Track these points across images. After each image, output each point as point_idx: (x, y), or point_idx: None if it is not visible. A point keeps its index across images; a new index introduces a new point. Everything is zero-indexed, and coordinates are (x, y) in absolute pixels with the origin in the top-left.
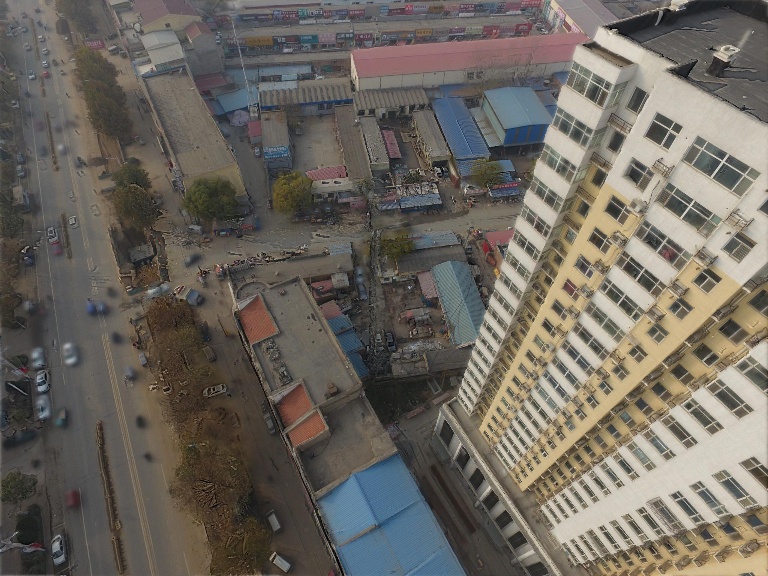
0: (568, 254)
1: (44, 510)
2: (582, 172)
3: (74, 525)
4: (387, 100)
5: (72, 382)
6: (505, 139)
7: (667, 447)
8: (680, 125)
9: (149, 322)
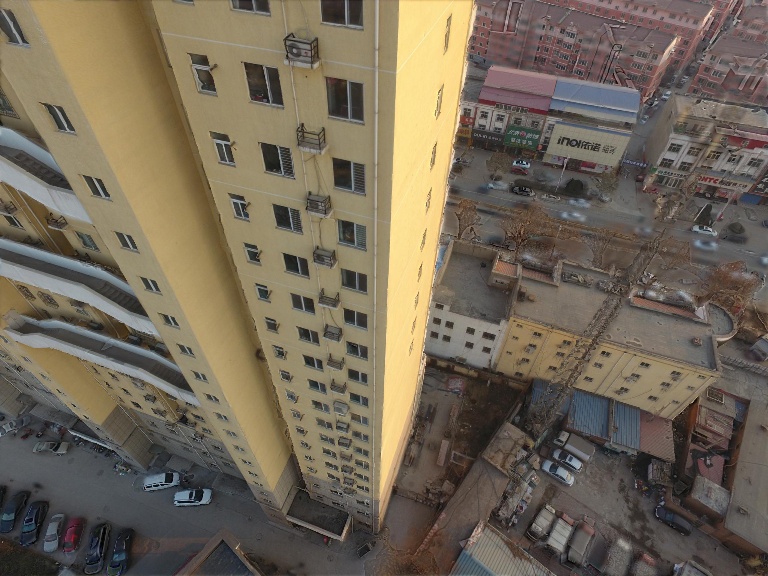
0: None
1: None
2: None
3: (562, 208)
4: None
5: (692, 244)
6: None
7: None
8: None
9: None
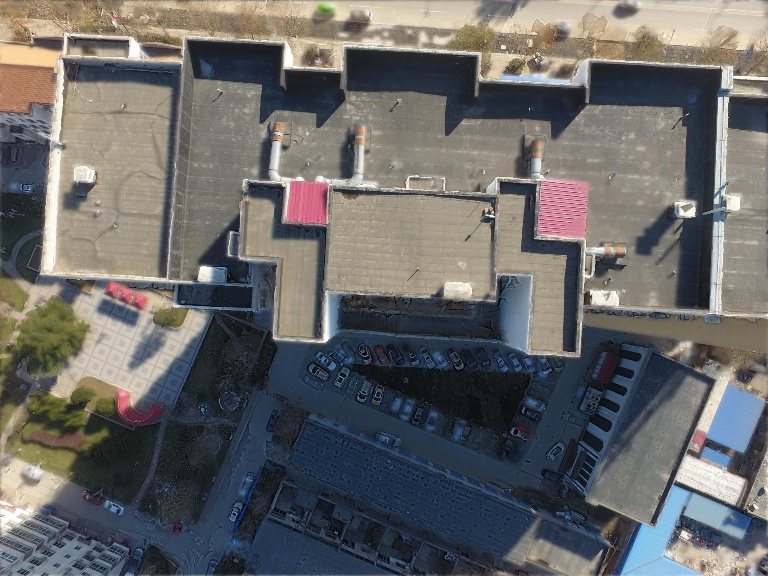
0: None
1: None
2: None
3: None
4: None
5: None
6: None
7: None
8: None
9: None
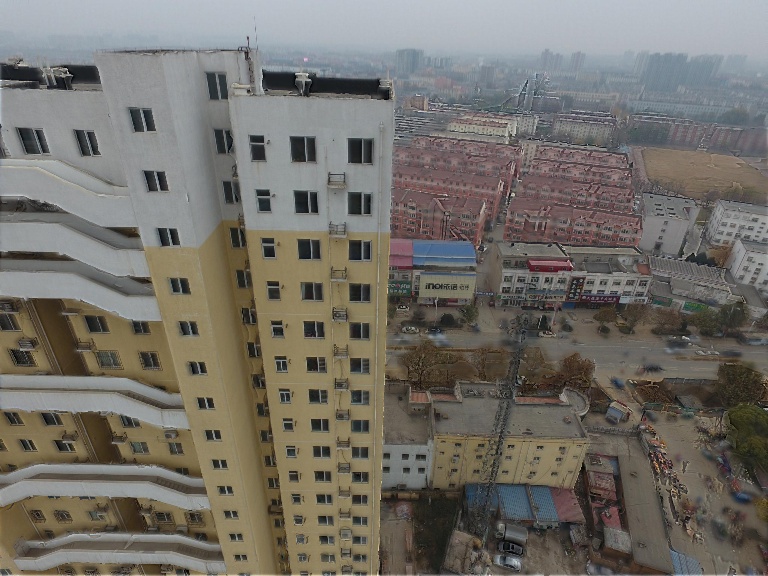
0: None
1: None
2: None
3: (443, 338)
4: None
5: (543, 346)
6: None
7: None
8: None
9: None
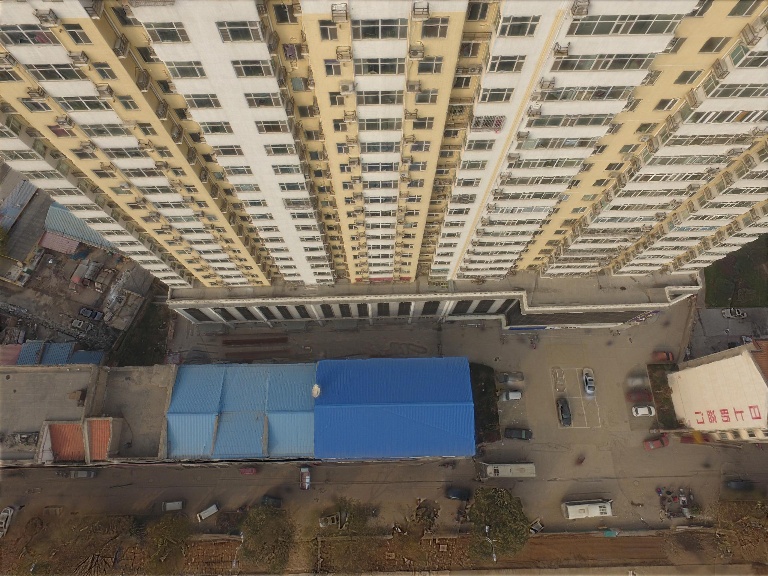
0: None
1: None
2: None
3: None
4: None
5: None
6: None
7: (241, 167)
8: None
9: None
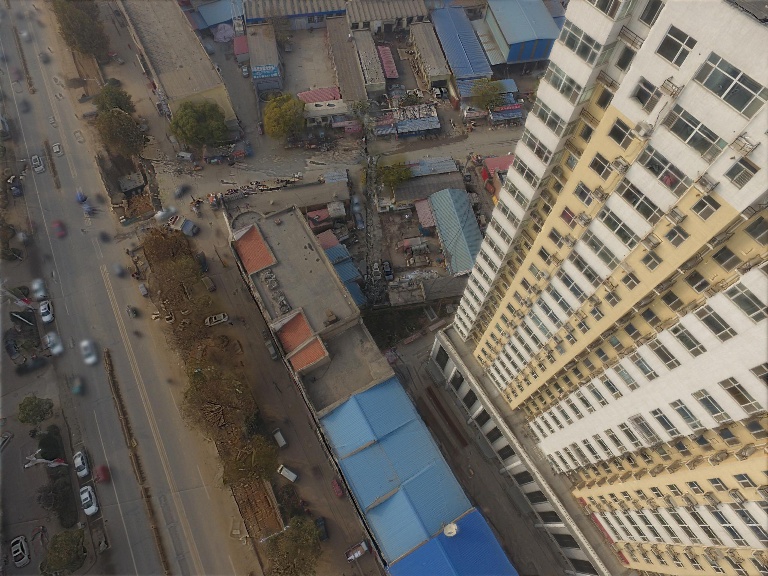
0: (568, 181)
1: (63, 430)
2: (587, 93)
3: (93, 443)
4: (383, 11)
5: (75, 312)
6: (509, 56)
7: (651, 369)
8: (695, 39)
9: (146, 253)
